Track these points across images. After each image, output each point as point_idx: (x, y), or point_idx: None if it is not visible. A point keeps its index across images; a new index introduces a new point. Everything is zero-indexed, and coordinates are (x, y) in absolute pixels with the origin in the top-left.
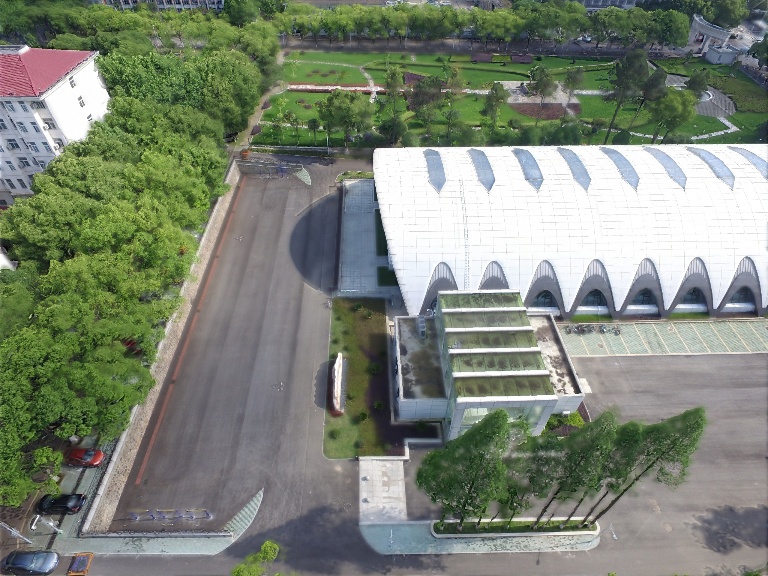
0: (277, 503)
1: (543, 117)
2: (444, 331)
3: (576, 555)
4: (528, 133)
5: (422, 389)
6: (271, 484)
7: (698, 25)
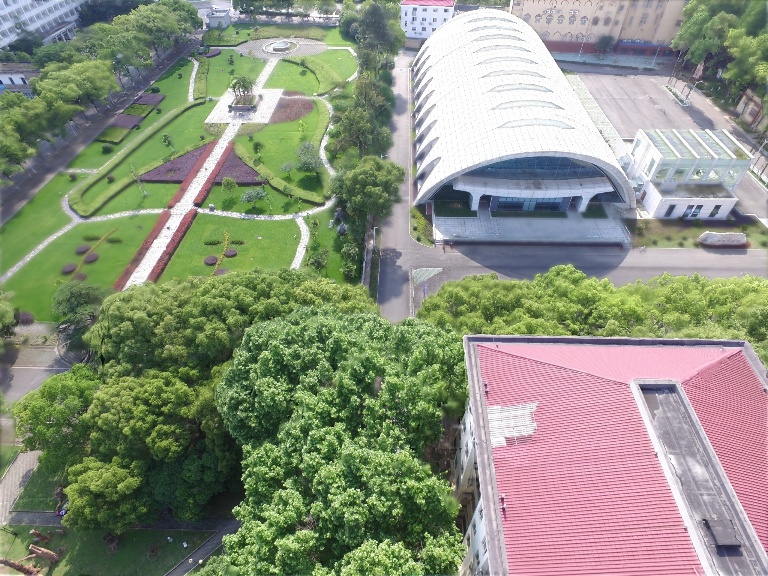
0: None
1: (306, 110)
2: (697, 160)
3: (761, 170)
4: None
5: (719, 193)
6: None
7: None
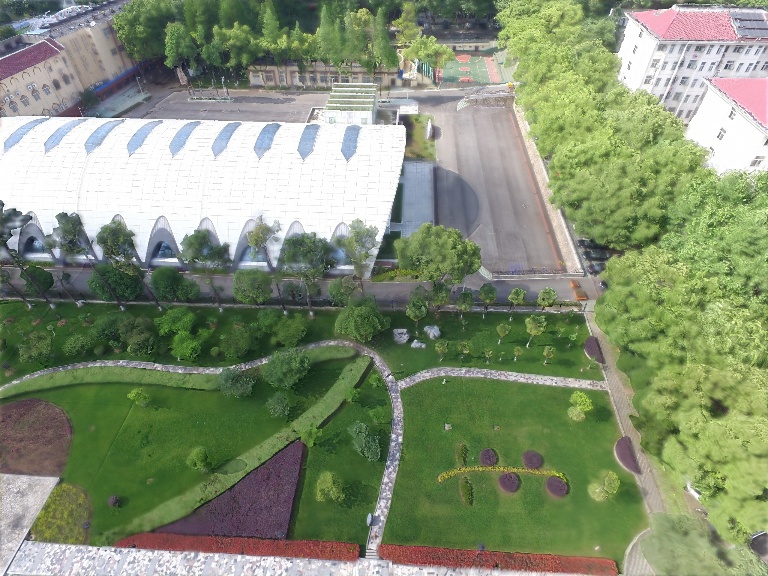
0: (451, 107)
1: (39, 410)
2: None
3: None
4: (173, 268)
5: None
6: (455, 111)
7: None
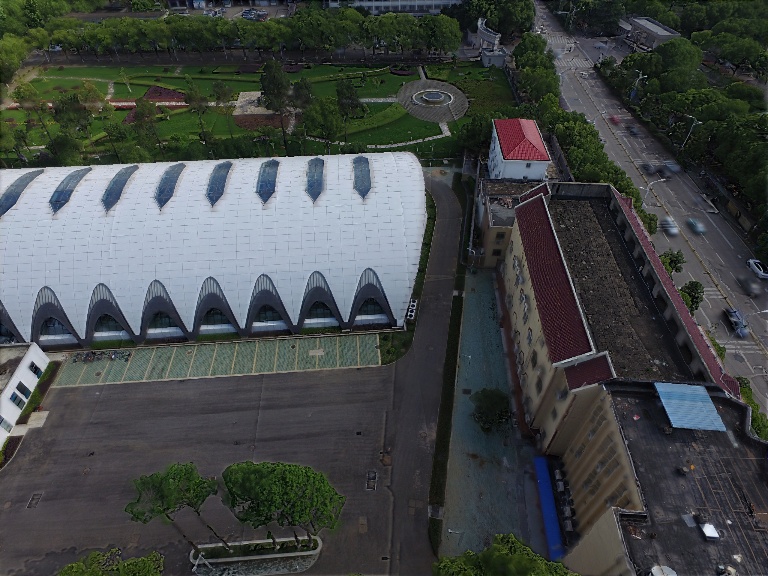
0: None
1: None
2: None
3: None
4: None
5: None
6: None
7: (478, 29)
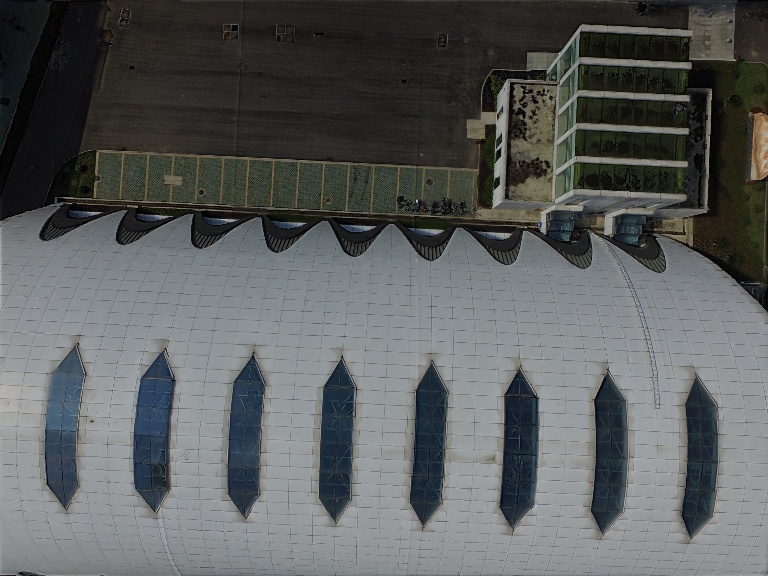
0: None
1: None
2: None
3: None
4: None
5: None
6: None
7: None
